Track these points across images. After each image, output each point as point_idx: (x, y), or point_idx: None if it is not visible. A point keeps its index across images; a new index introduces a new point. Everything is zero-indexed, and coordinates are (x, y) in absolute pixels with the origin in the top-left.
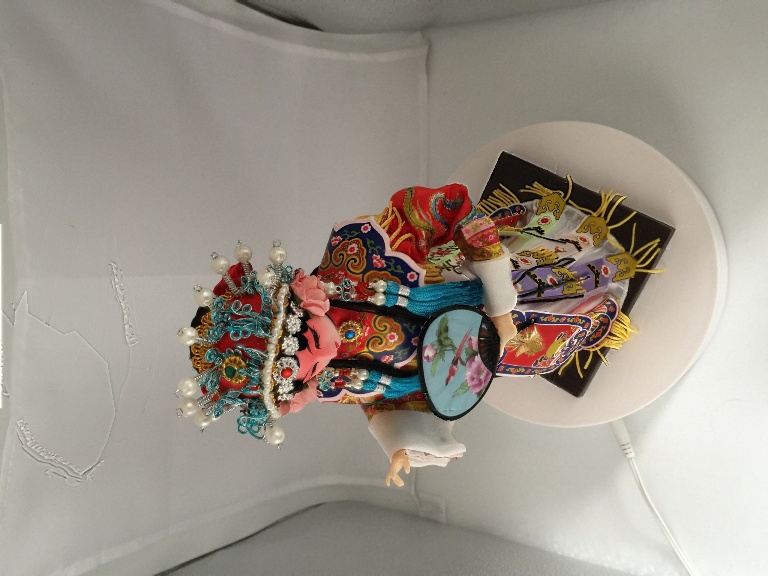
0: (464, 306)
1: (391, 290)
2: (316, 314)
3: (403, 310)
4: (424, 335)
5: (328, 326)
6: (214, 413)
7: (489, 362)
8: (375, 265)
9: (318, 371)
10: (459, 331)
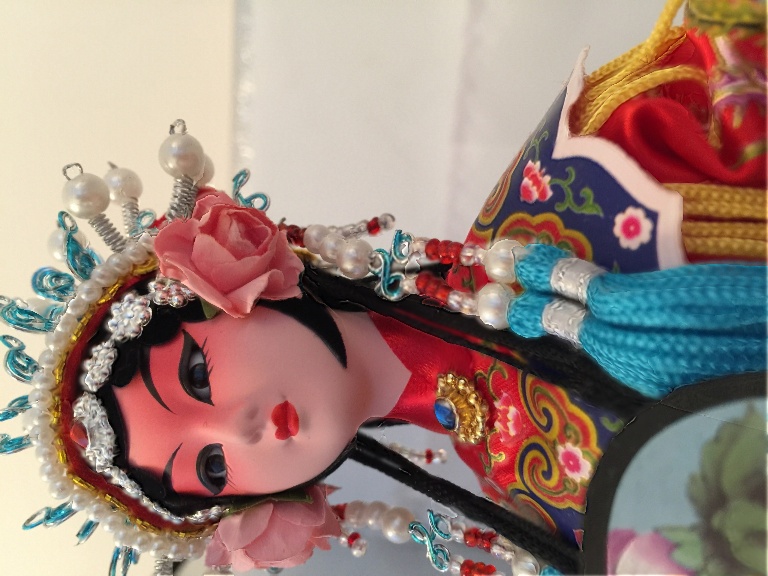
0: None
1: (521, 273)
2: None
3: (585, 360)
4: (616, 478)
5: (258, 350)
6: None
7: None
8: (524, 195)
9: (245, 474)
10: None
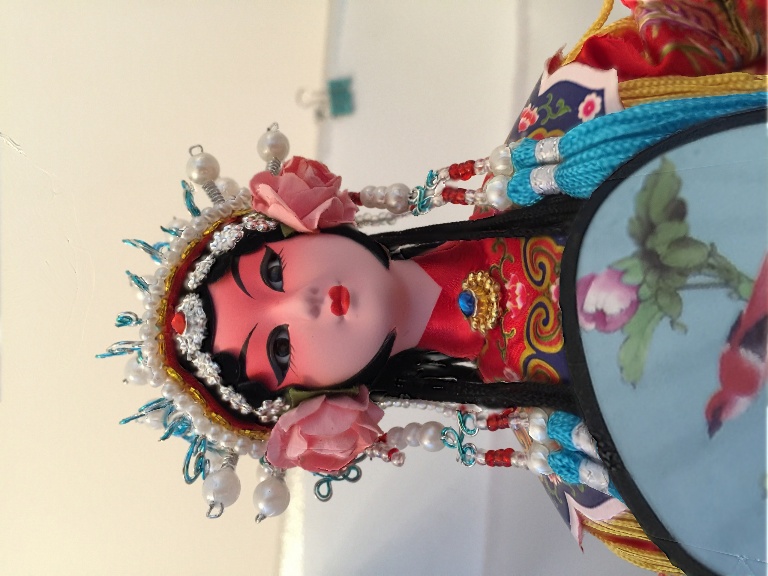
0: (759, 112)
1: (515, 157)
2: None
3: (563, 203)
4: (579, 243)
5: (322, 250)
6: None
7: None
8: (521, 128)
9: (305, 353)
10: (750, 209)
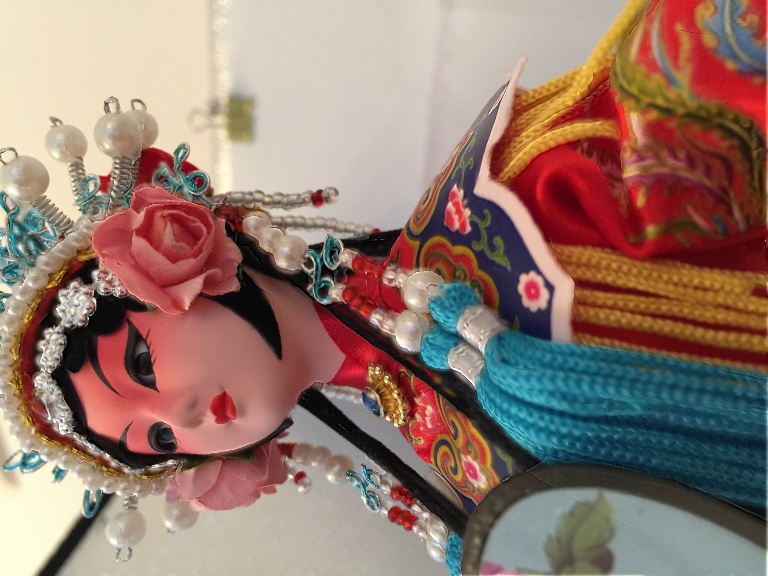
0: (727, 511)
1: (432, 313)
2: None
3: None
4: (490, 522)
5: (197, 345)
6: None
7: None
8: (447, 221)
9: (192, 444)
10: None
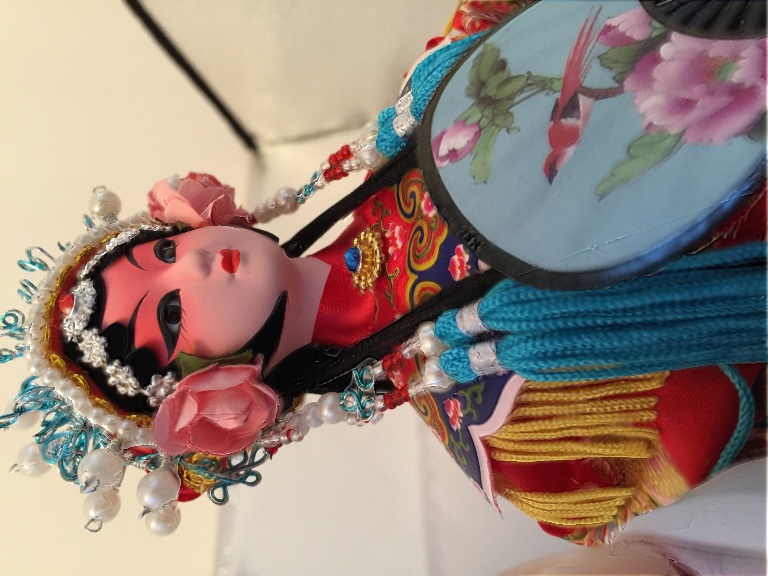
0: None
1: (380, 120)
2: (195, 222)
3: None
4: (430, 120)
5: None
6: (53, 453)
7: (760, 22)
8: None
9: (196, 314)
10: (550, 43)
